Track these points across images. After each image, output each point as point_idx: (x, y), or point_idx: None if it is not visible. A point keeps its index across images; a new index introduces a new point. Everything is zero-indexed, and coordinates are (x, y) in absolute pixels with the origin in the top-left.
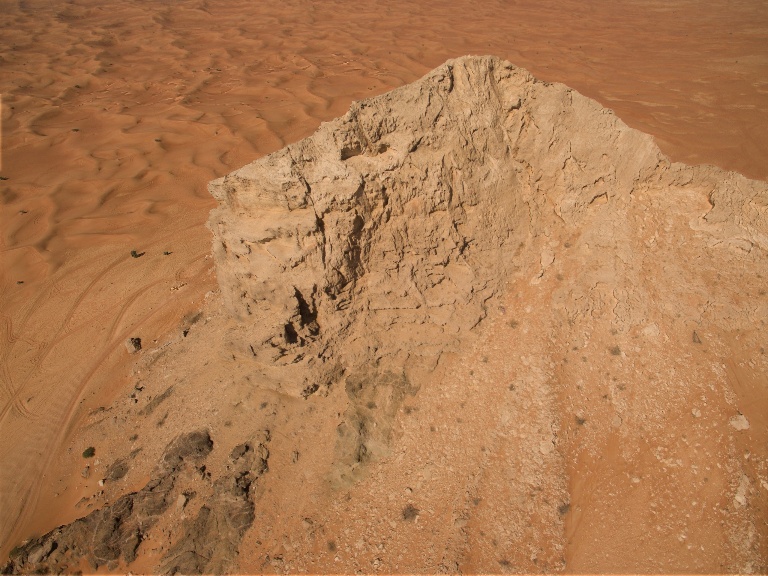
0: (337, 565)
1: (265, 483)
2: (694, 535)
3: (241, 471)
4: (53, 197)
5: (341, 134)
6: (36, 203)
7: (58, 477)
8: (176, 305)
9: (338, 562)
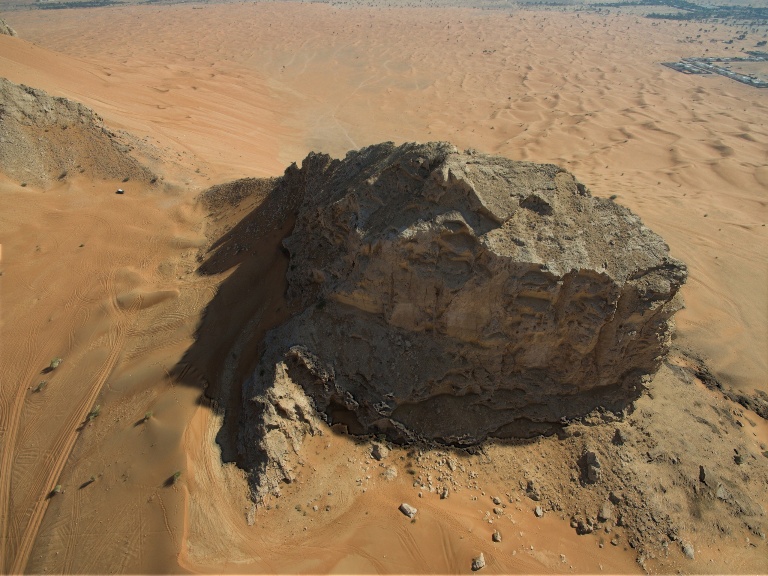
0: None
1: None
2: None
3: None
4: None
5: None
6: None
7: None
8: (741, 575)
9: None
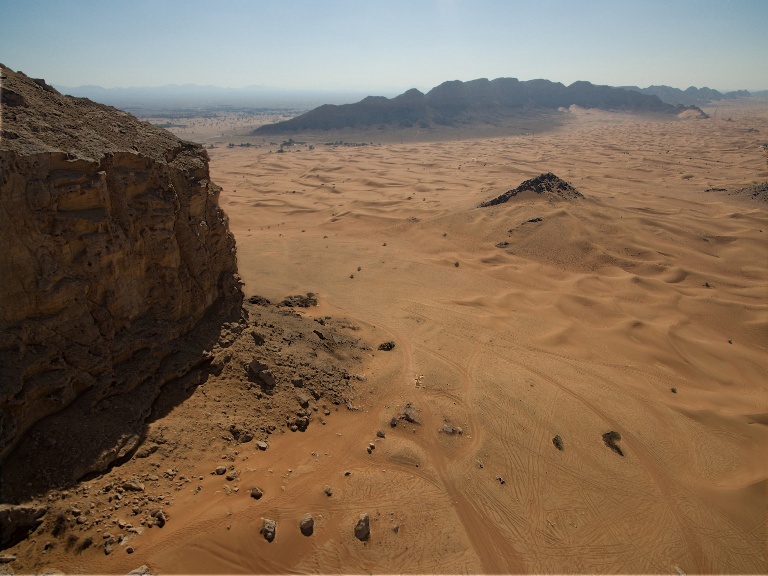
0: None
1: None
2: None
3: None
4: None
5: None
6: None
7: (337, 315)
8: (390, 367)
9: None
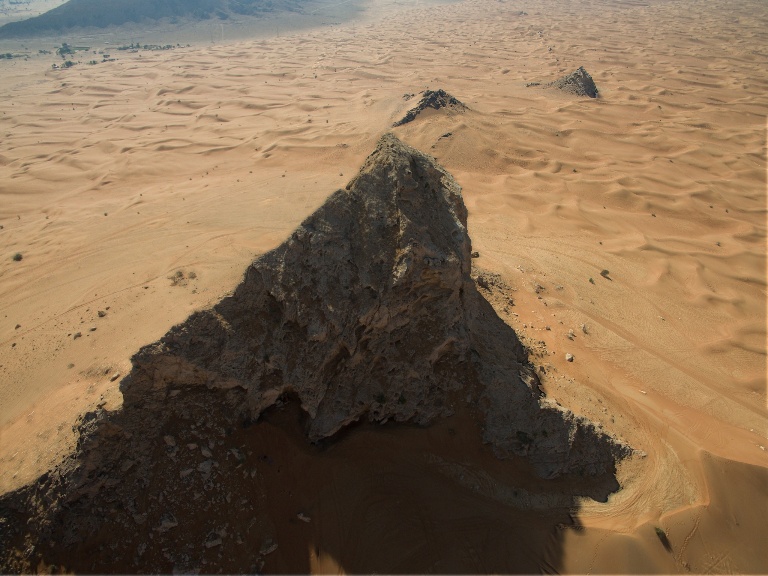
0: None
1: None
2: (130, 353)
3: None
4: (745, 254)
5: None
6: (734, 248)
7: None
8: (499, 265)
9: None
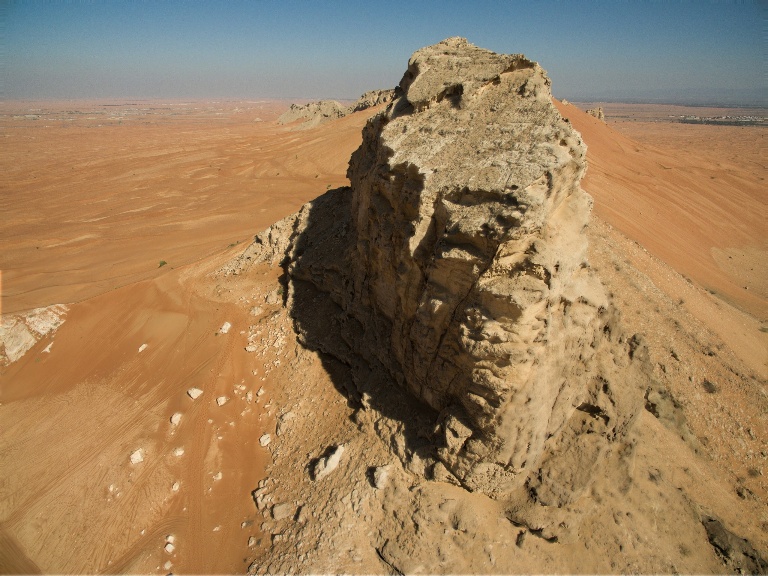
0: (767, 475)
1: (728, 528)
2: None
3: (743, 541)
4: None
5: (547, 88)
6: None
7: None
8: None
9: (764, 473)
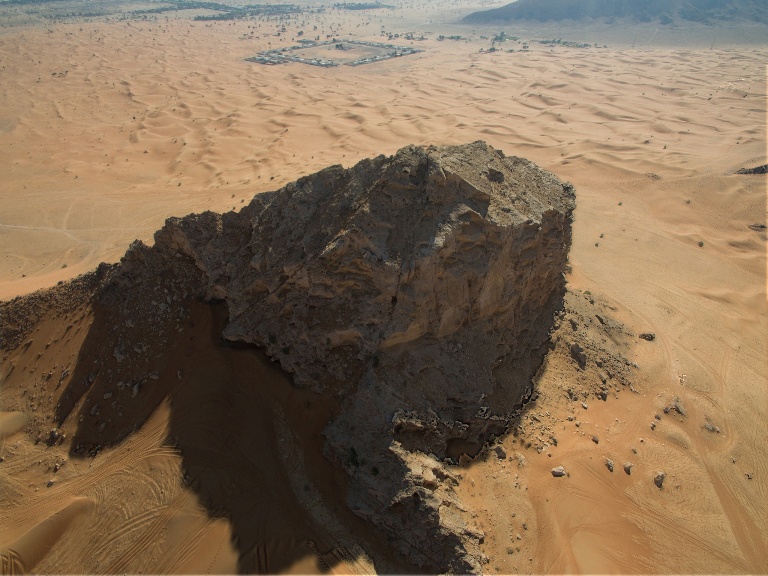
0: None
1: None
2: None
3: None
4: None
5: None
6: None
7: (592, 289)
8: (656, 360)
9: None
